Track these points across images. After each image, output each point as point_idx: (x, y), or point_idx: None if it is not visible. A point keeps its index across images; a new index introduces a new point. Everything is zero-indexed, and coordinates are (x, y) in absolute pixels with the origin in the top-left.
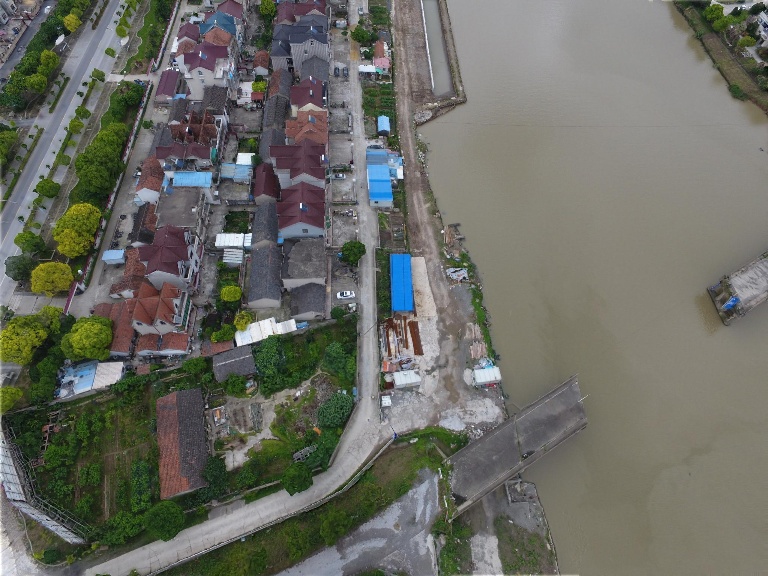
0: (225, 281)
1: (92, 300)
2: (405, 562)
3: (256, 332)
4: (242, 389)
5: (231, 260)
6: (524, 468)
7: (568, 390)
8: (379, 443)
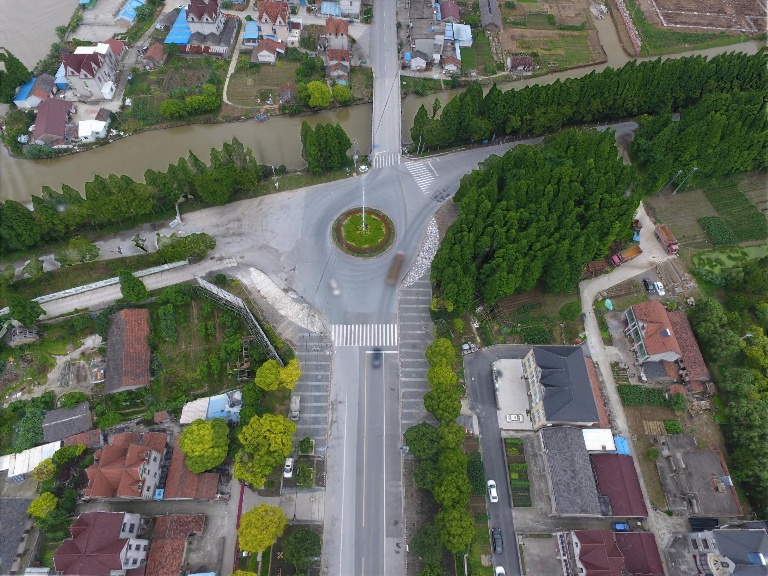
0: (60, 539)
1: (231, 513)
2: None
3: (35, 458)
4: None
5: (39, 572)
6: None
7: None
8: None
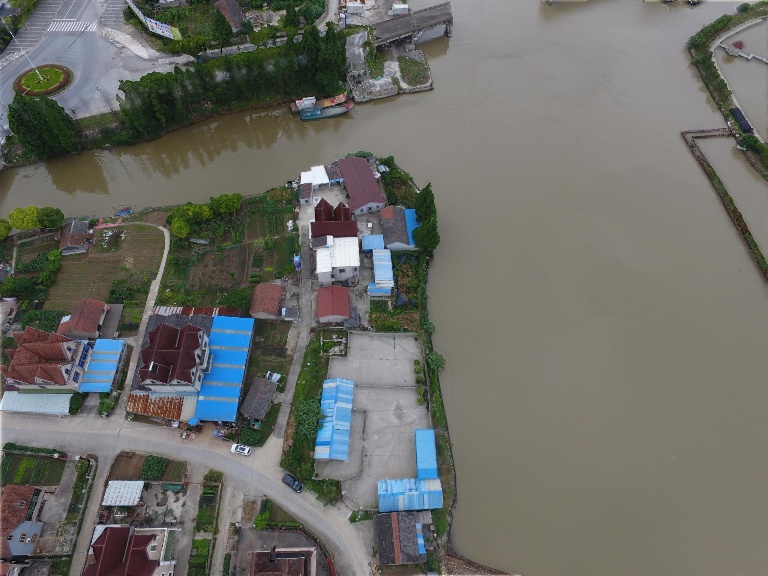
0: None
1: None
2: (347, 55)
3: None
4: (261, 5)
5: None
6: (414, 28)
7: (444, 8)
8: (337, 29)
